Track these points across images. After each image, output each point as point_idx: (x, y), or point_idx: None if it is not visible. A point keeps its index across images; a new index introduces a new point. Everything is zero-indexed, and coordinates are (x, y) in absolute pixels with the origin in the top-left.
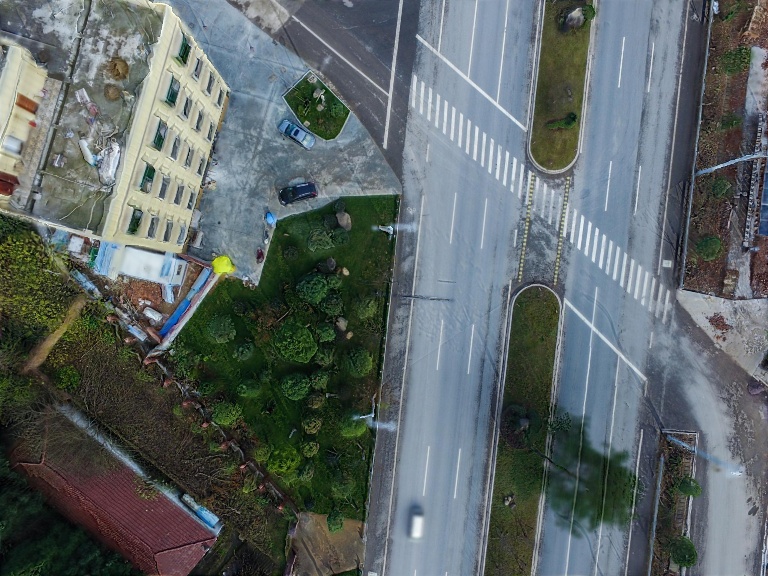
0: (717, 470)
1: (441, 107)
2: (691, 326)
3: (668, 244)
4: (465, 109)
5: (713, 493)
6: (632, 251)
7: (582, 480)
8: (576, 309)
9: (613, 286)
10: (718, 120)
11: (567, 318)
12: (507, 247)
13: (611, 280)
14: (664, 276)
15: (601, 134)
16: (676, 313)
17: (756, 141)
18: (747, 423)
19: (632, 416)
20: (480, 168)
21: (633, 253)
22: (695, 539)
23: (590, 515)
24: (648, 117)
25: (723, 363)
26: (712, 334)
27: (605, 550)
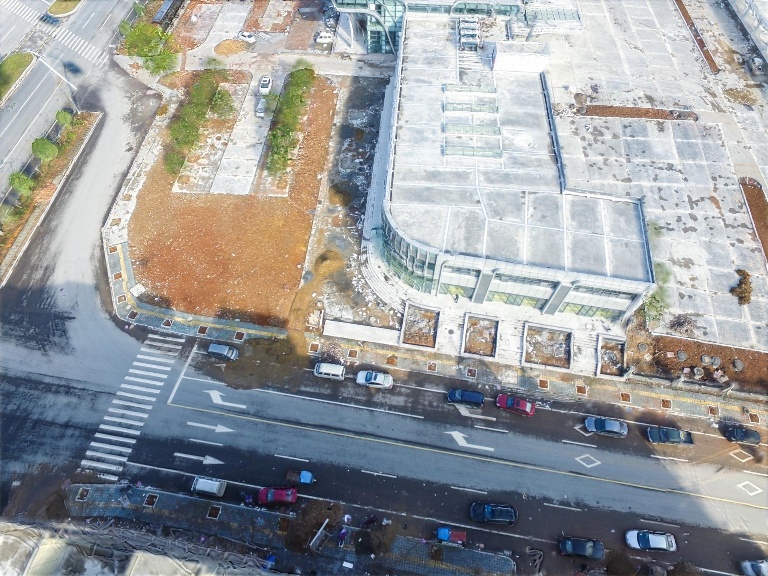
0: (110, 130)
1: (10, 0)
2: (117, 68)
3: (116, 39)
4: (22, 0)
5: (102, 141)
6: (92, 41)
7: (7, 134)
8: (45, 62)
9: (74, 54)
10: (163, 1)
11: (37, 65)
12: (16, 41)
13: (73, 51)
14: (108, 50)
15: (93, 5)
16: (110, 64)
17: (181, 5)
18: (139, 107)
19: (59, 105)
20: (18, 17)
21: (92, 42)
22: (79, 166)
23: (3, 151)
24: (123, 0)
25: (133, 82)
26: (130, 71)
27: (4, 170)
